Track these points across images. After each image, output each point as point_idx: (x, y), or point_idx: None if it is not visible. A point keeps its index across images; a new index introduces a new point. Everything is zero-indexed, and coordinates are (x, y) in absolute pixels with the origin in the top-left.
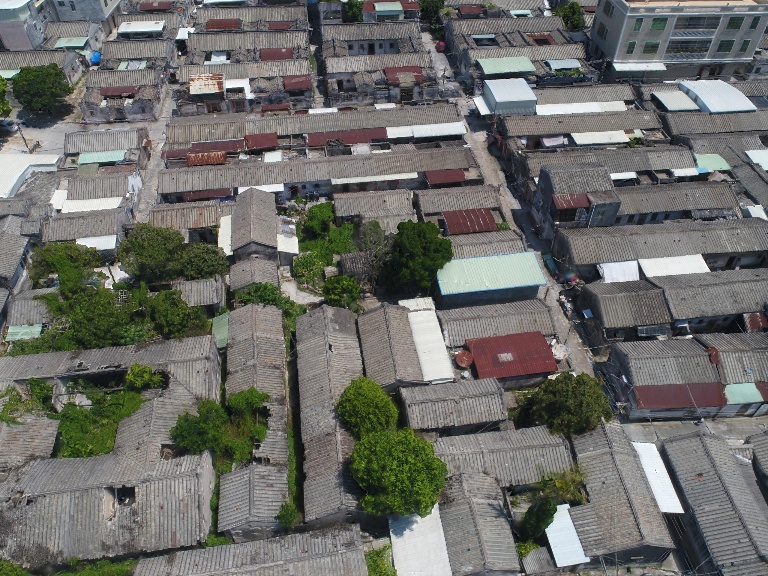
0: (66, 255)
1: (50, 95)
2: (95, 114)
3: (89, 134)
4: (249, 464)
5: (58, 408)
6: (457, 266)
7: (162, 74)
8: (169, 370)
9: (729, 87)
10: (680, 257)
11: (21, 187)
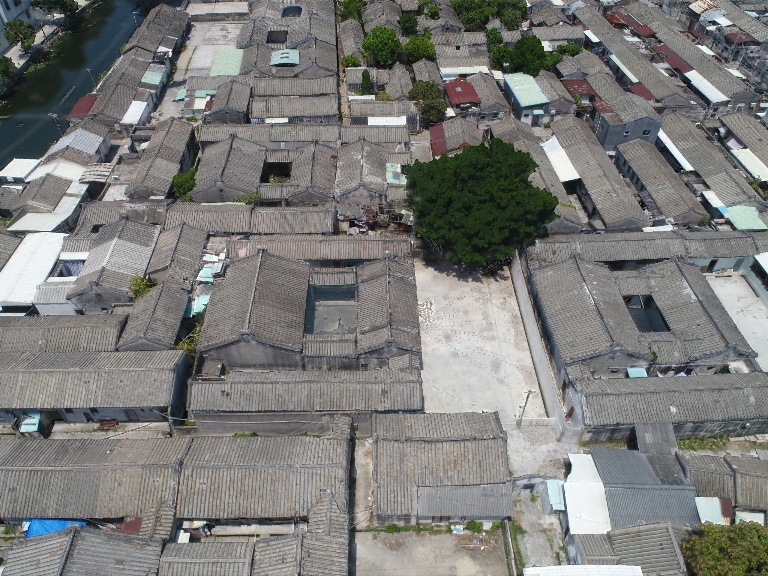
0: None
1: None
2: None
3: None
4: None
5: (425, 10)
6: (527, 78)
7: None
8: None
9: None
10: (573, 167)
11: None
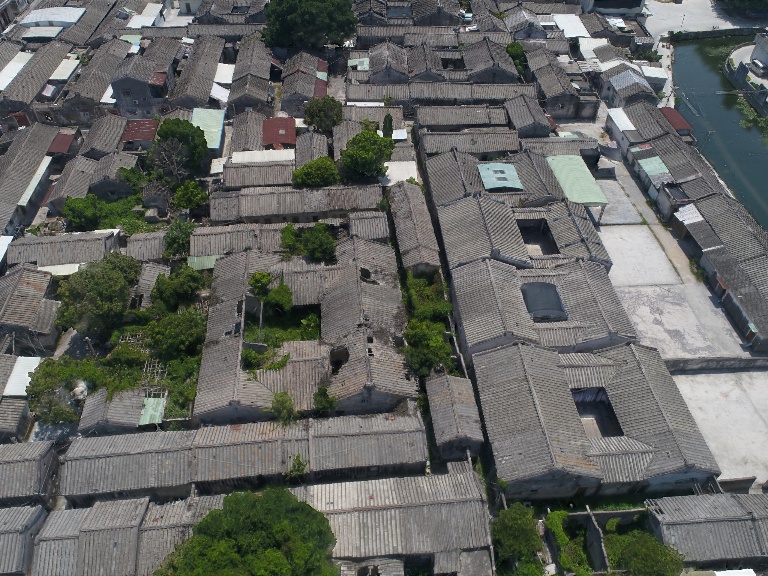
0: (61, 366)
1: None
2: None
3: None
4: (338, 238)
5: None
6: None
7: None
8: None
9: (49, 9)
10: (218, 69)
11: None
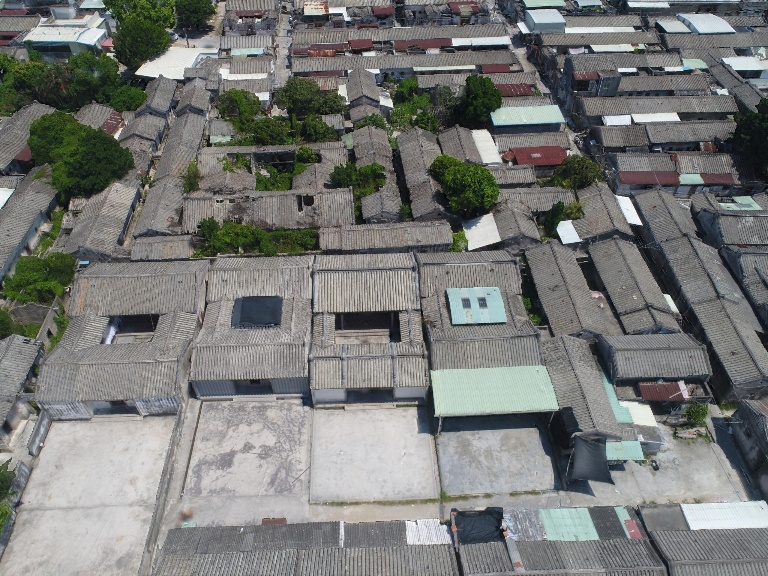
0: (243, 96)
1: (203, 13)
2: (233, 29)
3: (237, 36)
4: None
5: None
6: (505, 111)
7: (279, 4)
8: (321, 153)
9: (716, 18)
10: (661, 114)
11: (196, 66)
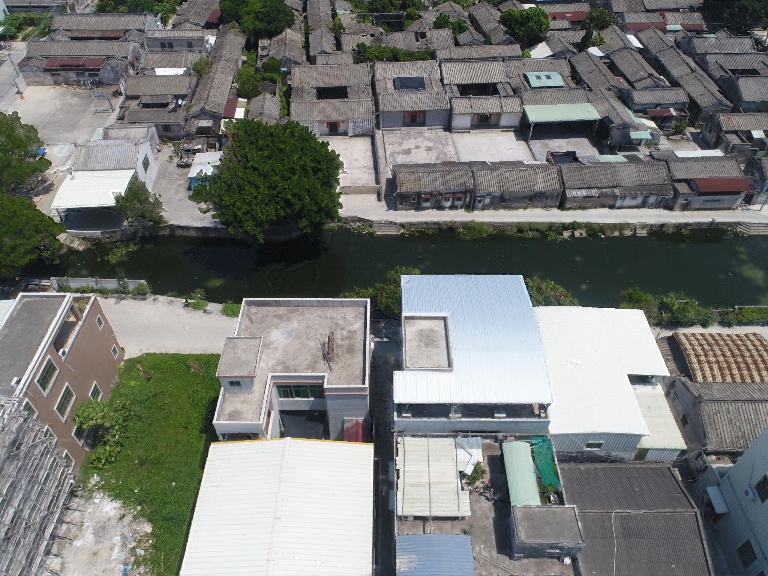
0: None
1: None
2: None
3: None
4: None
5: None
6: None
7: None
8: (421, 14)
9: None
10: None
11: None
